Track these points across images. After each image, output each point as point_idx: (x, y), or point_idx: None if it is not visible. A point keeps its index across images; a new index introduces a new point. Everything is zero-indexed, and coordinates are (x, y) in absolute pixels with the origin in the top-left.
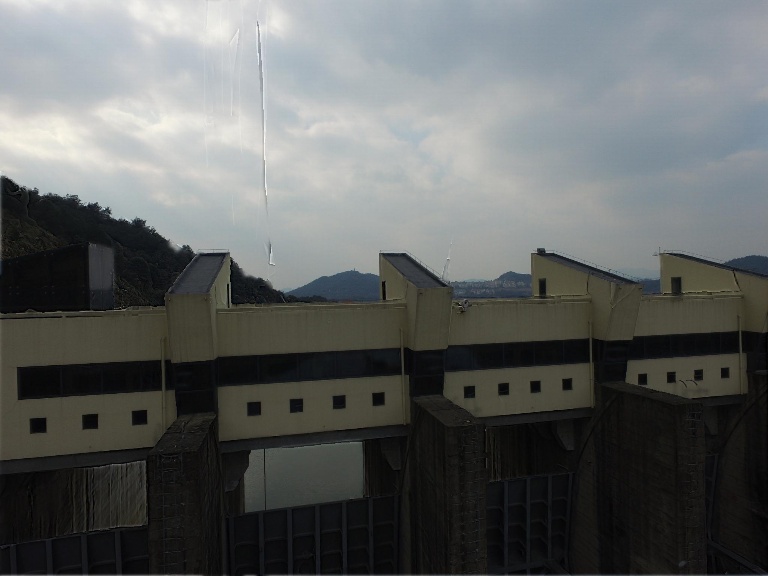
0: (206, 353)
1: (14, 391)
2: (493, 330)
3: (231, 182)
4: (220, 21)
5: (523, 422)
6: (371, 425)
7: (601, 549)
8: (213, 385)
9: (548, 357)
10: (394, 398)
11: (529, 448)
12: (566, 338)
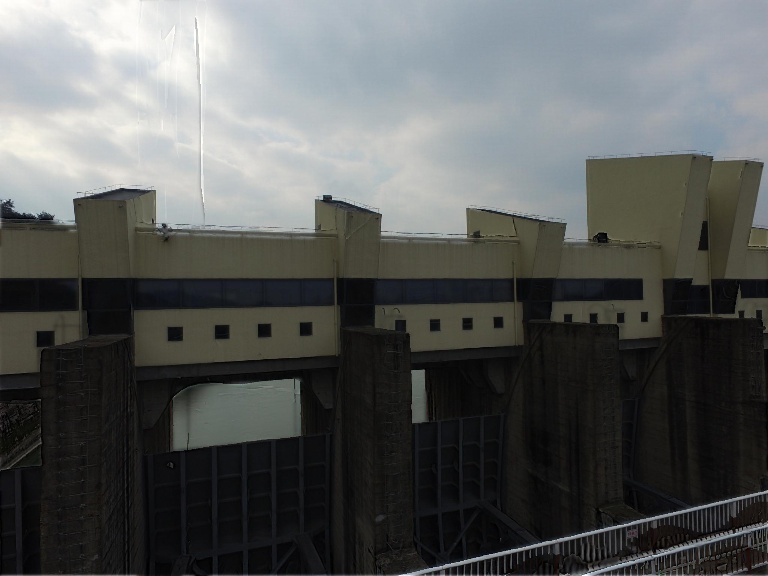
0: None
1: None
2: (210, 263)
3: (164, 182)
4: (156, 16)
5: (250, 371)
6: (34, 370)
7: (344, 516)
8: None
9: (285, 298)
10: (69, 338)
11: (316, 415)
12: (305, 277)
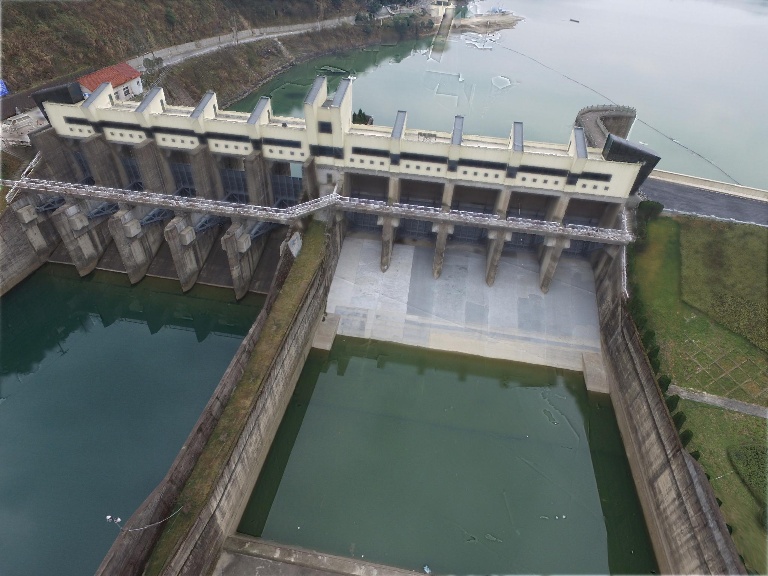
0: (94, 120)
1: (64, 121)
2: (166, 123)
3: None
4: None
5: (182, 150)
6: None
7: None
8: (99, 127)
9: (186, 134)
10: (144, 137)
11: None
12: (189, 129)
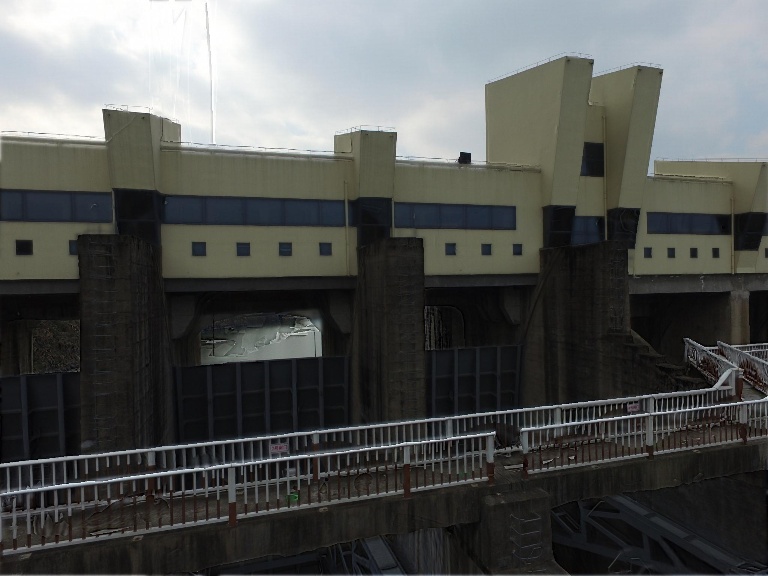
0: None
1: None
2: None
3: None
4: None
5: (9, 292)
6: None
7: None
8: None
9: (53, 213)
10: None
11: None
12: (76, 189)
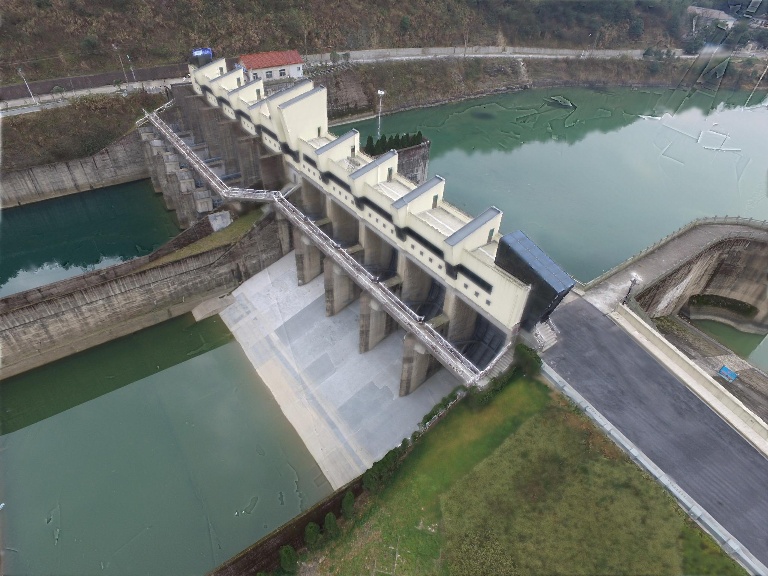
0: None
1: None
2: None
3: None
4: None
5: None
6: None
7: None
8: None
9: None
10: None
11: None
12: None
